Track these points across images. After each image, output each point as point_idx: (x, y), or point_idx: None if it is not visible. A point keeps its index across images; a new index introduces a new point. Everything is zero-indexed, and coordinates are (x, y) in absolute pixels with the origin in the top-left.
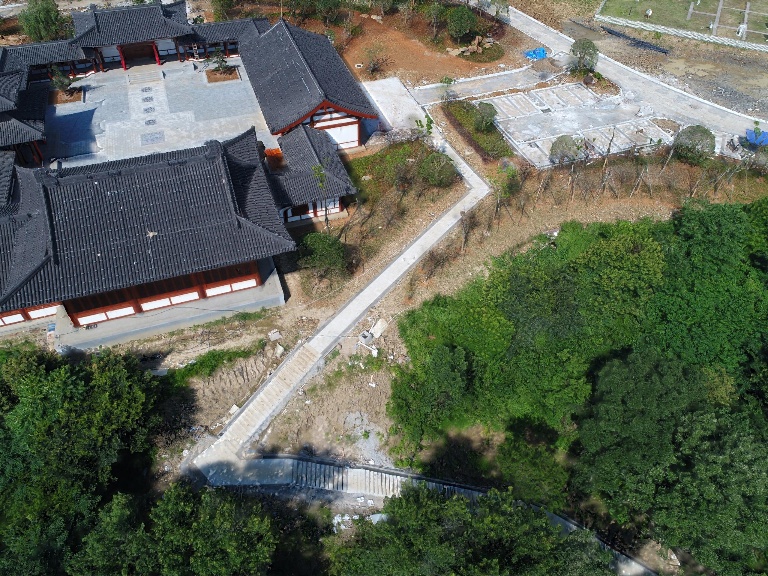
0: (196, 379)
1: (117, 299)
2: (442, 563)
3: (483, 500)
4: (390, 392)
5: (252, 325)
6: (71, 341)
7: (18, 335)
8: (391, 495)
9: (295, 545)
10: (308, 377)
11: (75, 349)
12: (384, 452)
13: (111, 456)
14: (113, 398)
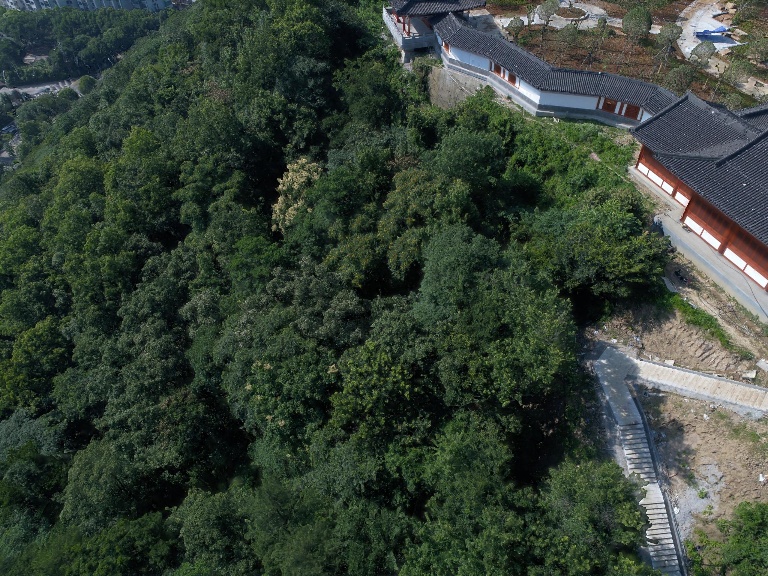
0: (679, 315)
1: (720, 228)
2: (576, 531)
3: (655, 571)
4: (764, 501)
5: (764, 343)
6: (666, 223)
7: (657, 199)
8: (649, 536)
9: (568, 446)
10: (733, 408)
11: (662, 230)
12: (694, 523)
13: (582, 274)
14: (626, 255)
